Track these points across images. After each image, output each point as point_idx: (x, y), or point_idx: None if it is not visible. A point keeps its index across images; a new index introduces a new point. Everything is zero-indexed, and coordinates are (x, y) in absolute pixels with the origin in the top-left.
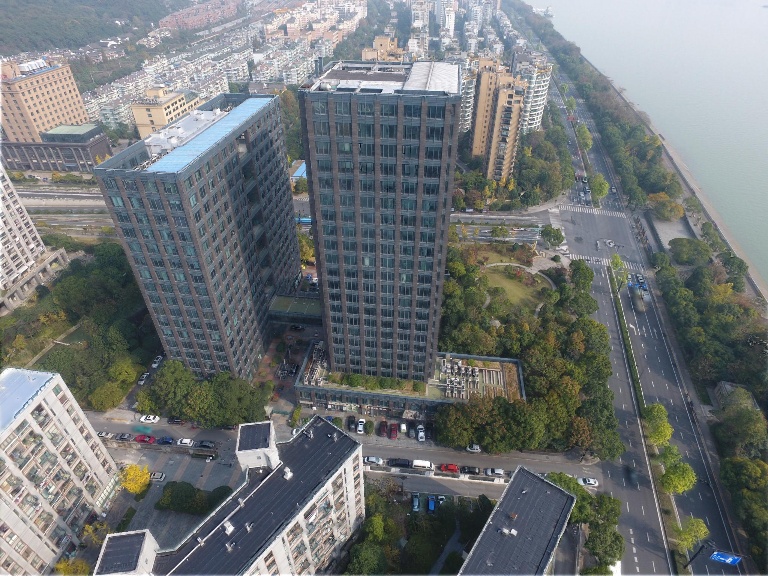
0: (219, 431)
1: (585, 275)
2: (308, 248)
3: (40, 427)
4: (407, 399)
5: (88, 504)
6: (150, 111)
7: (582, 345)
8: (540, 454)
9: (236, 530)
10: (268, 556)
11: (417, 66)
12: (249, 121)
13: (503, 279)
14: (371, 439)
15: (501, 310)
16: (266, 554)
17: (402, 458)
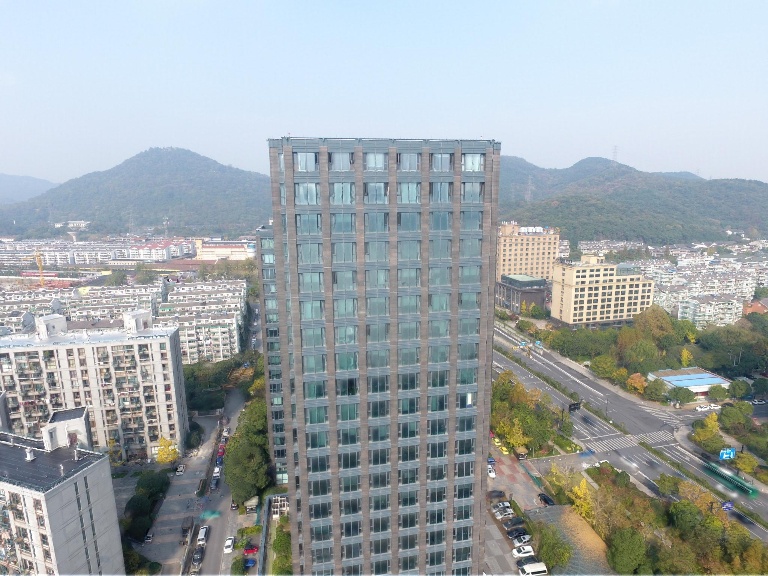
0: None
1: None
2: (520, 431)
3: (140, 358)
4: None
5: (145, 441)
6: (565, 271)
7: None
8: None
9: None
10: None
11: None
12: None
13: None
14: None
15: None
16: None
17: None
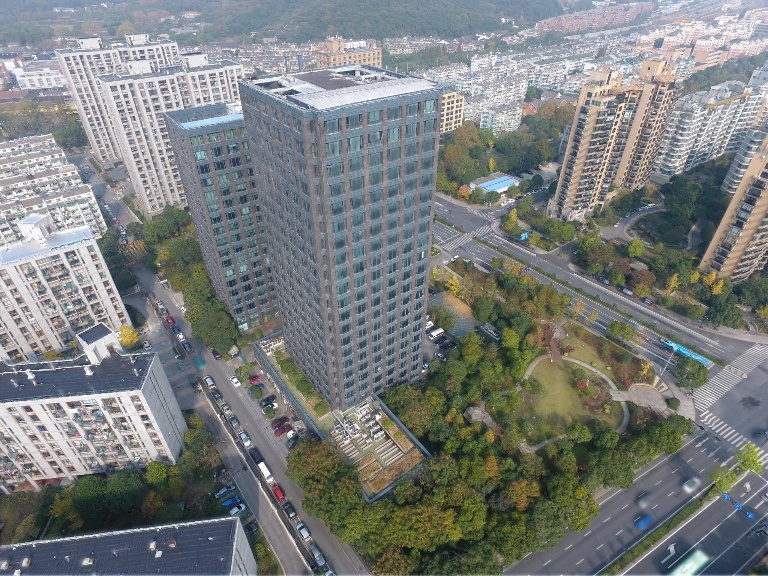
0: (203, 344)
1: (659, 439)
2: None
3: (70, 265)
4: (300, 410)
5: None
6: None
7: (523, 500)
8: (359, 558)
9: (34, 380)
10: (29, 408)
11: (395, 80)
12: None
13: (562, 381)
14: (265, 423)
15: (499, 405)
16: (23, 404)
17: (263, 454)
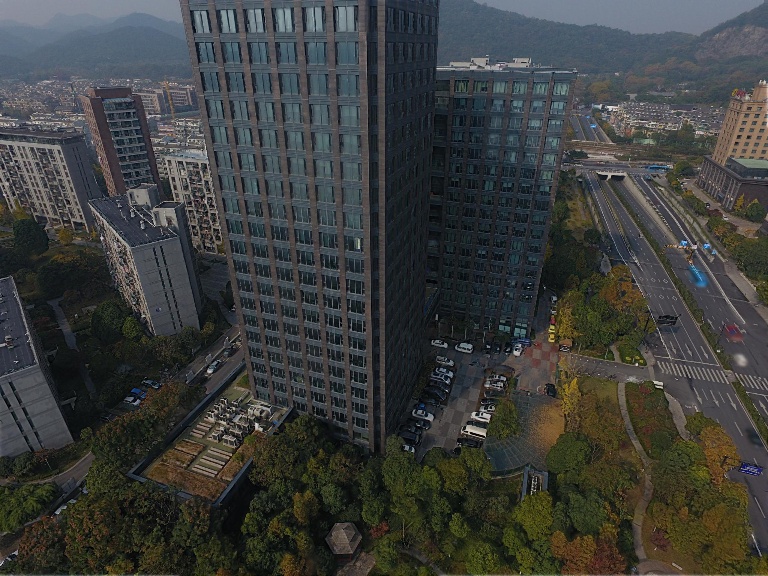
0: None
1: None
2: (569, 323)
3: None
4: None
5: None
6: None
7: None
8: None
9: None
10: None
11: None
12: (461, 73)
13: None
14: None
15: None
16: None
17: None
